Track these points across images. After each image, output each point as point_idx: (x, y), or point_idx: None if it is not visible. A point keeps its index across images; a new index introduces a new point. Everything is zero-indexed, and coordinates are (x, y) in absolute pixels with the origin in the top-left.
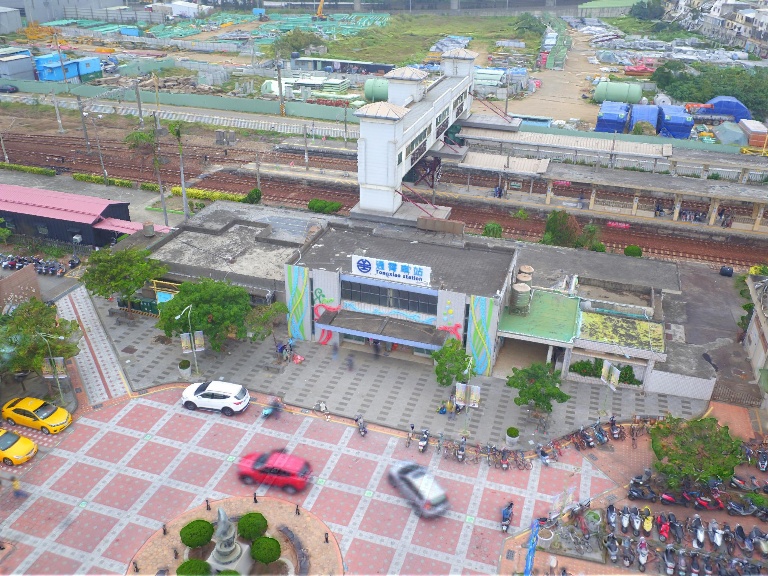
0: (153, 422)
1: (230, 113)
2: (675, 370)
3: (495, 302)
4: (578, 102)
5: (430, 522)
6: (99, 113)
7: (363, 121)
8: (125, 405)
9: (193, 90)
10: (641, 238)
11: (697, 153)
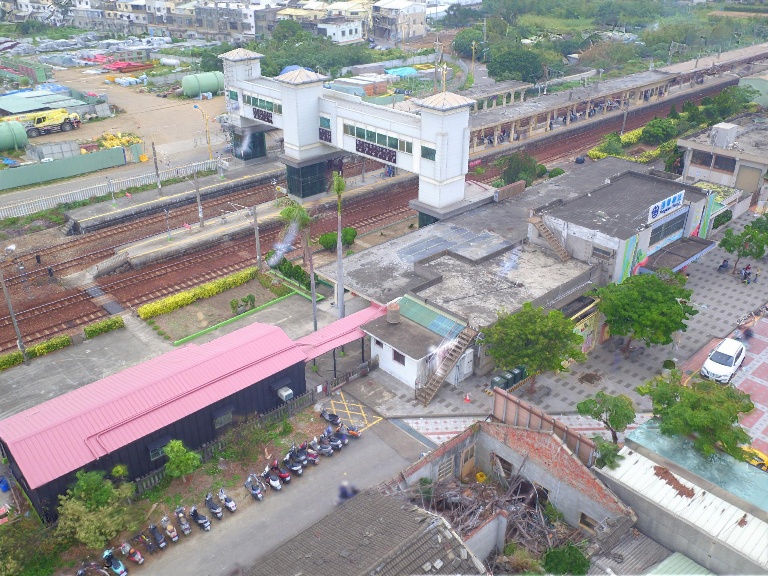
0: None
1: None
2: None
3: None
4: (172, 101)
5: None
6: None
7: (445, 115)
8: None
9: None
10: None
11: None
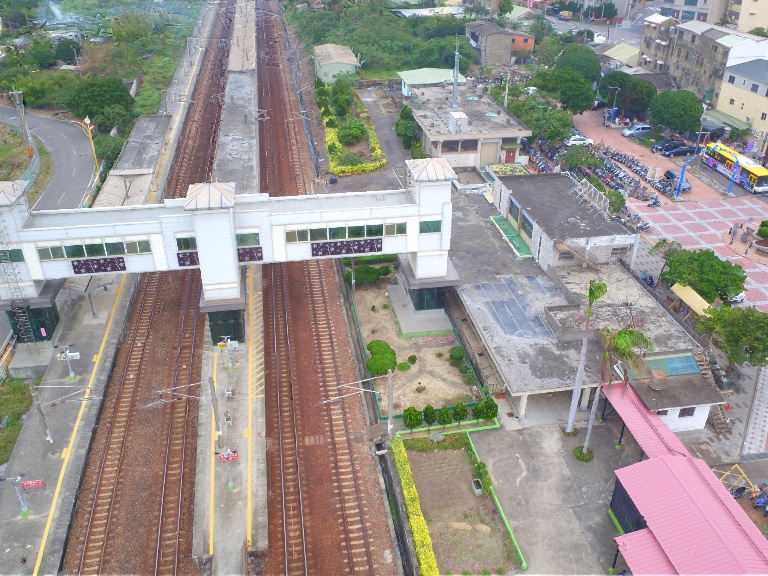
0: None
1: None
2: None
3: None
4: None
5: (680, 219)
6: None
7: None
8: None
9: None
10: None
11: (127, 165)
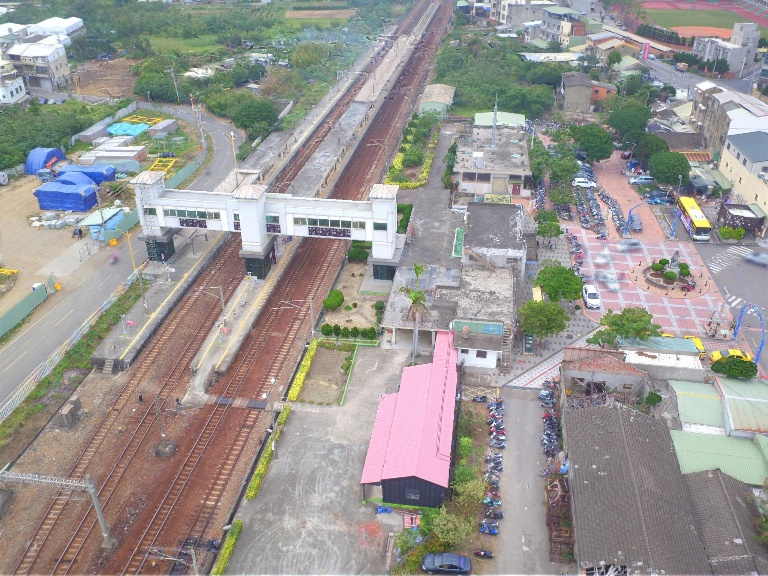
0: None
1: None
2: None
3: None
4: None
5: None
6: None
7: None
8: None
9: None
10: None
11: None
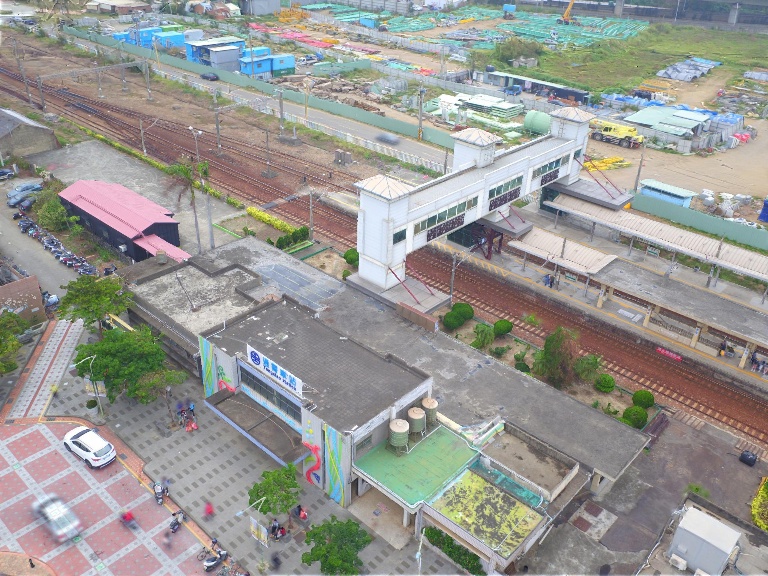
0: (32, 452)
1: (373, 129)
2: (550, 574)
3: (342, 439)
4: None
5: None
6: (261, 113)
7: (363, 193)
8: (28, 428)
9: (364, 97)
10: (684, 379)
11: None
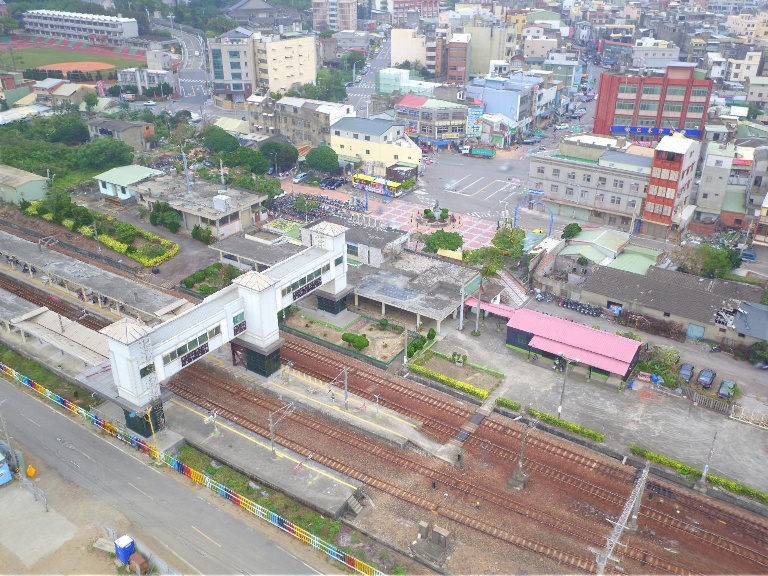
0: None
1: None
2: None
3: None
4: None
5: None
6: None
7: None
8: None
9: None
10: None
11: (7, 313)
